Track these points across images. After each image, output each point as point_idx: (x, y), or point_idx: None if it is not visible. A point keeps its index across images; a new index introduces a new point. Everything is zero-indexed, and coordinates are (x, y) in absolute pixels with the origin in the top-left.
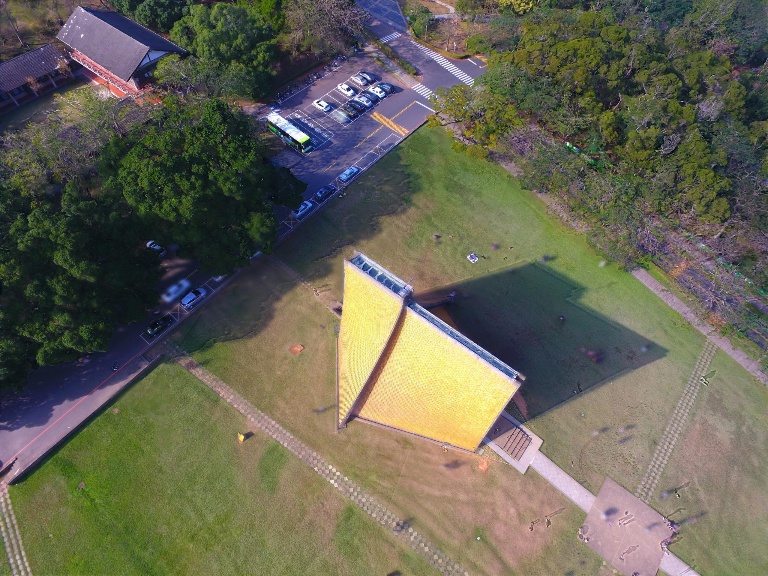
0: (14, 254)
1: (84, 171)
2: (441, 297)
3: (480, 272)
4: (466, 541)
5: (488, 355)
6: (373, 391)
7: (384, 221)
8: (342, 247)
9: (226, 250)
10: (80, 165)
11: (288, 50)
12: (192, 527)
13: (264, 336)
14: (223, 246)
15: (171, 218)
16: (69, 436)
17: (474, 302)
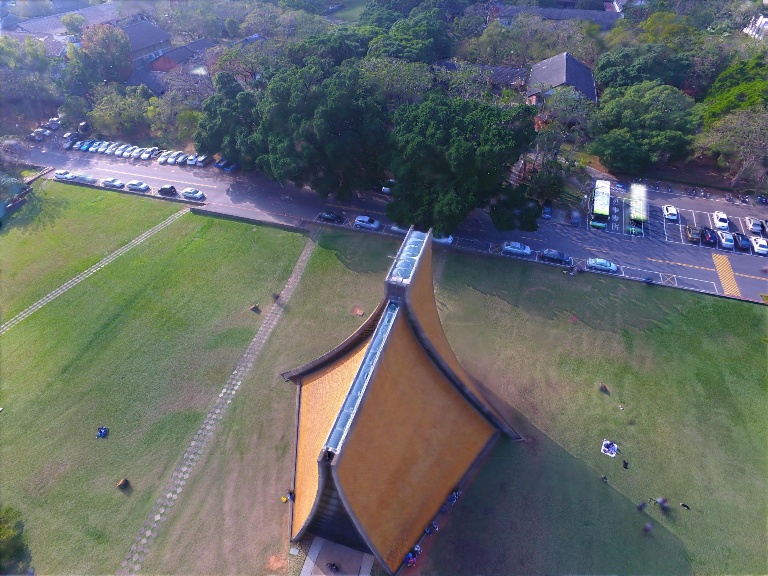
0: (309, 94)
1: (405, 97)
2: (509, 424)
3: (593, 466)
4: (170, 570)
5: (356, 405)
6: (325, 376)
7: (572, 323)
8: (502, 299)
9: (412, 205)
10: (403, 87)
11: (694, 150)
12: (171, 308)
13: (359, 282)
14: (413, 199)
15: (399, 145)
16: (229, 217)
17: (533, 472)
